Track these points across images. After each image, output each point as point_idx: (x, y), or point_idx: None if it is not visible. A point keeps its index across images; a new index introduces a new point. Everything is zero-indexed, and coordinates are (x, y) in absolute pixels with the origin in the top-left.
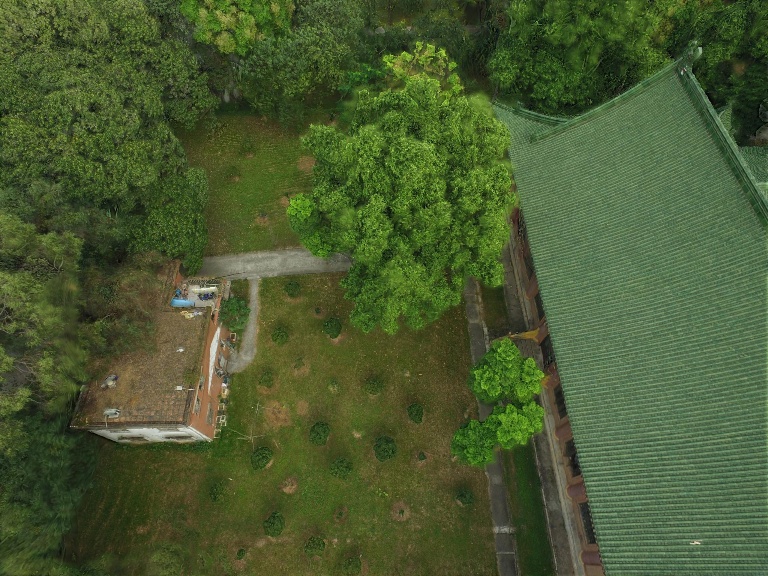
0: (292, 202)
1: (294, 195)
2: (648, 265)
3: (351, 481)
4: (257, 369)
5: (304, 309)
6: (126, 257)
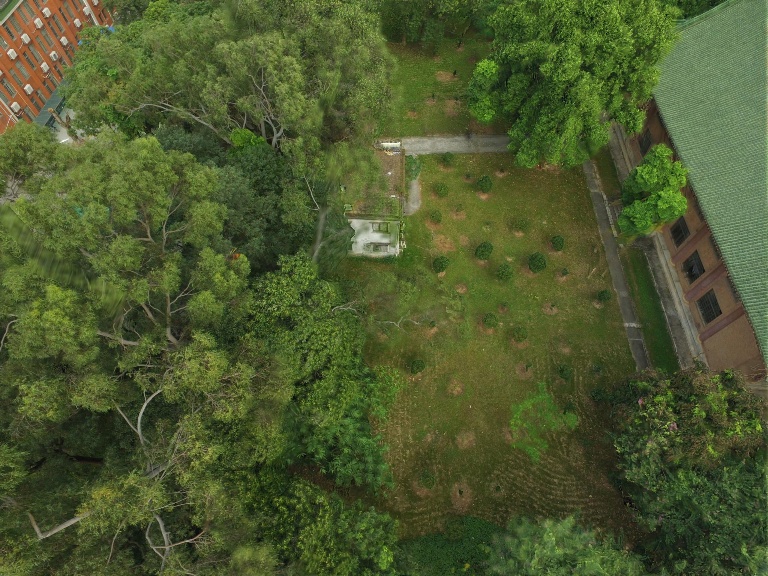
0: (480, 63)
1: (436, 98)
2: (764, 108)
3: (508, 288)
4: (424, 214)
5: (455, 176)
6: (343, 109)
